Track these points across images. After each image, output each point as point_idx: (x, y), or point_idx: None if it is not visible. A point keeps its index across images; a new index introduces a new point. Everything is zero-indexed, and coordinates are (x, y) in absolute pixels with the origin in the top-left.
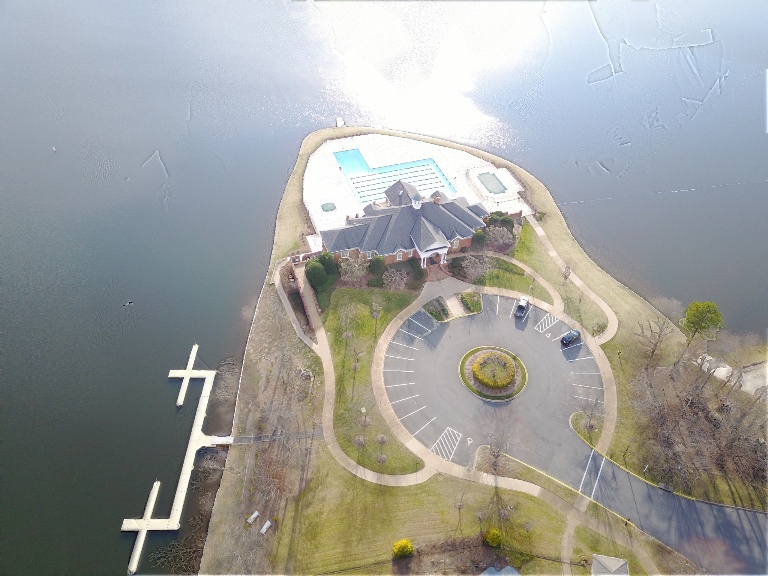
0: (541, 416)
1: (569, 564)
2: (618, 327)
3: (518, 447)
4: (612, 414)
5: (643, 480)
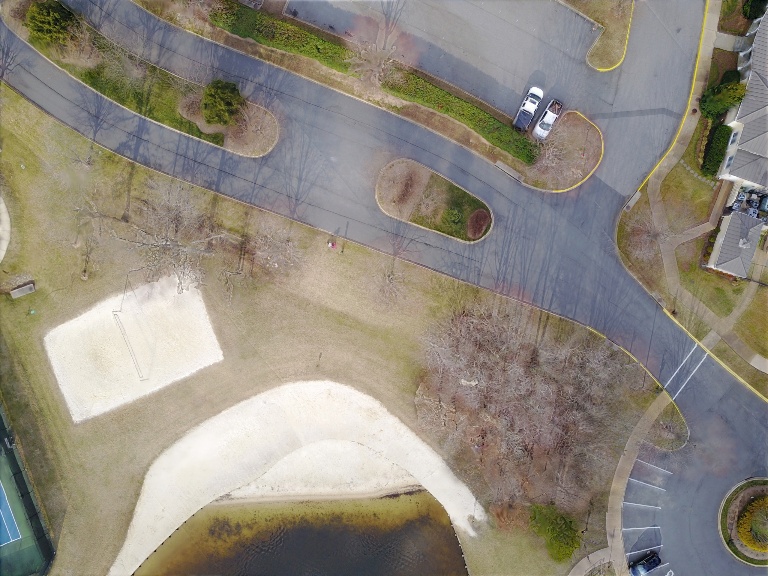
0: (721, 451)
1: (753, 280)
2: (568, 575)
3: (759, 415)
4: (633, 442)
5: (632, 356)
